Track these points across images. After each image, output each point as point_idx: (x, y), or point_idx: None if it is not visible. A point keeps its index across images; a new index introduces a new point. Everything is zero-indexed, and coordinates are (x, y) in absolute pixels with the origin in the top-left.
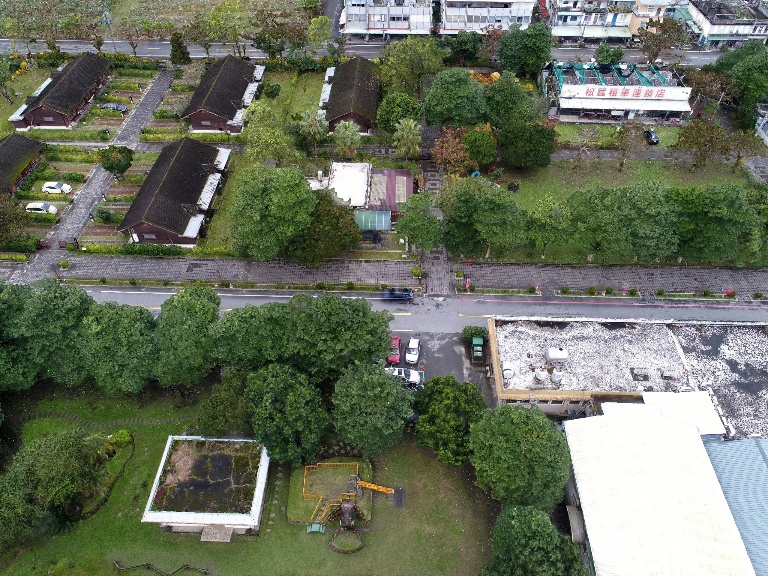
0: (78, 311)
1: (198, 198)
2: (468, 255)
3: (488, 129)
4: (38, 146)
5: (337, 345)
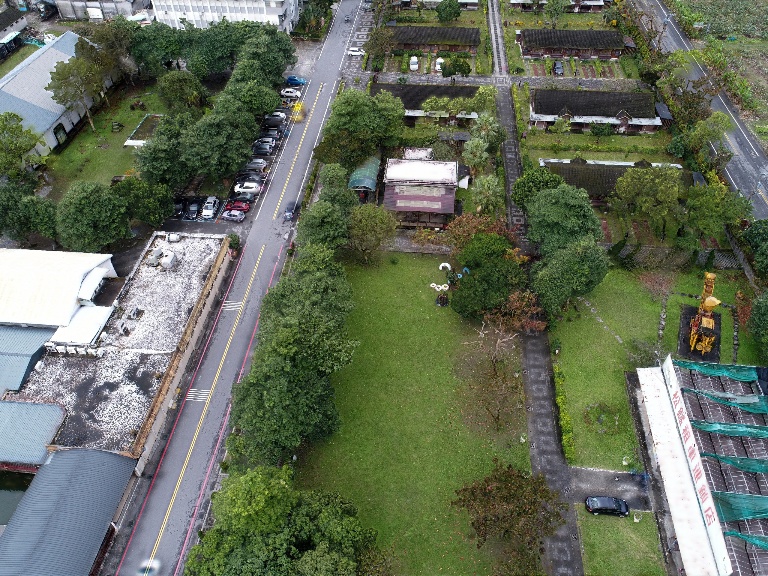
0: (252, 57)
1: (412, 109)
2: (336, 255)
3: (520, 259)
4: (475, 43)
5: (185, 130)
